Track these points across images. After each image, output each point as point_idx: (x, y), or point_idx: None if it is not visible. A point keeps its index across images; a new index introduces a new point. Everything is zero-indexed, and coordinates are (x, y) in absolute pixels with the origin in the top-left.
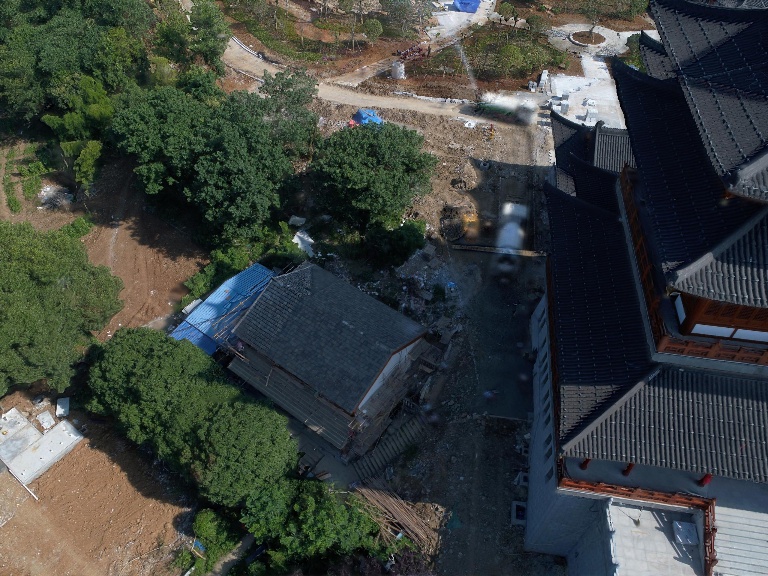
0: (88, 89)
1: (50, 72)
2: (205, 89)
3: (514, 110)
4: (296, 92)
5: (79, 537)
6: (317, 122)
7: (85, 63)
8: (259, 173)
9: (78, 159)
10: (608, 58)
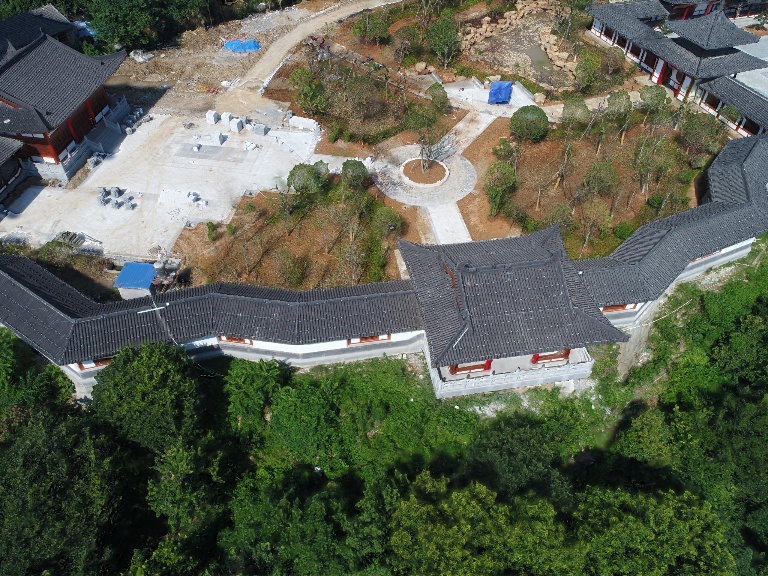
0: None
1: None
2: None
3: (247, 105)
4: None
5: None
6: None
7: None
8: None
9: None
10: (367, 179)
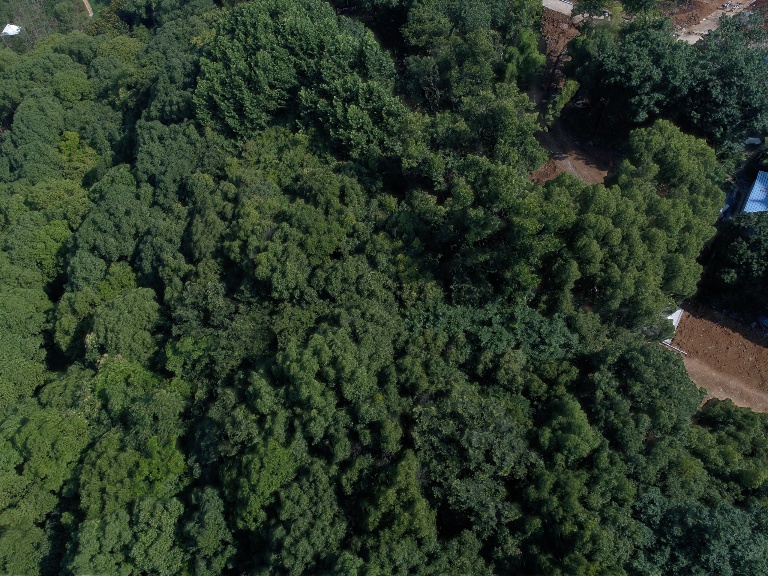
0: (528, 41)
1: (466, 30)
2: (664, 32)
3: None
4: (759, 29)
5: (742, 378)
6: None
7: (499, 21)
8: (762, 95)
9: (559, 97)
10: None
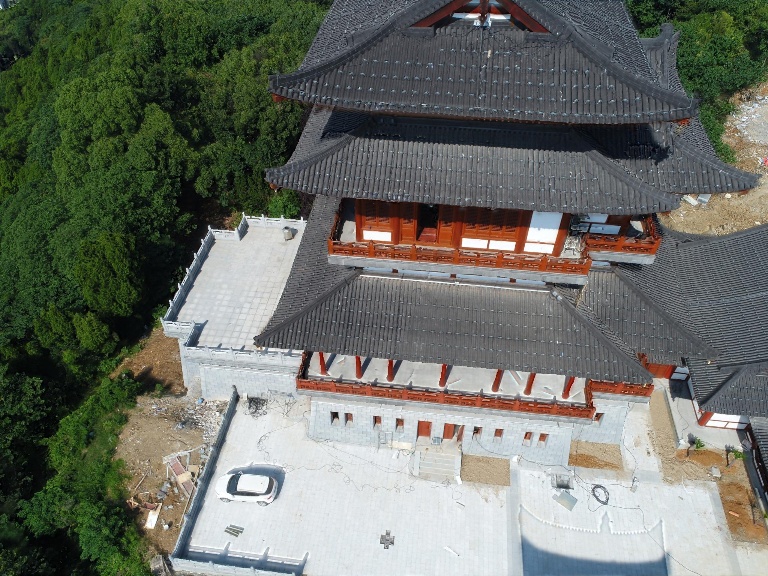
0: None
1: (715, 9)
2: None
3: None
4: None
5: None
6: (724, 111)
7: None
8: None
9: None
10: None
